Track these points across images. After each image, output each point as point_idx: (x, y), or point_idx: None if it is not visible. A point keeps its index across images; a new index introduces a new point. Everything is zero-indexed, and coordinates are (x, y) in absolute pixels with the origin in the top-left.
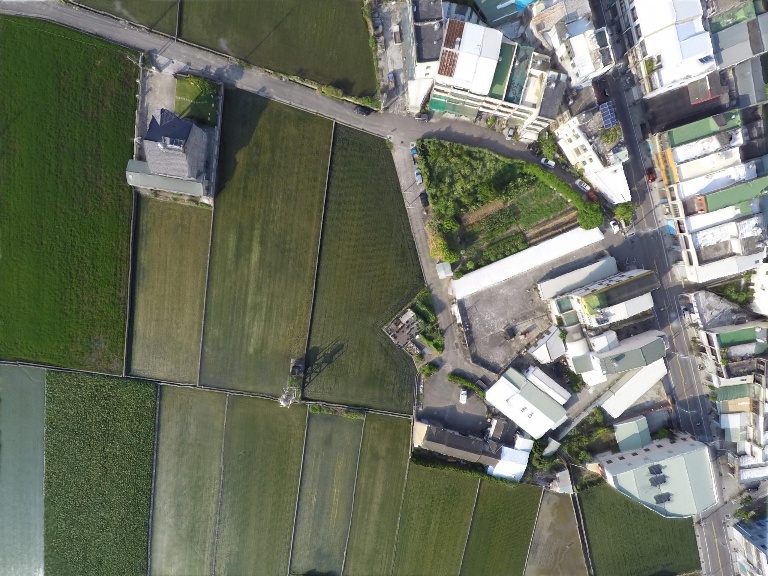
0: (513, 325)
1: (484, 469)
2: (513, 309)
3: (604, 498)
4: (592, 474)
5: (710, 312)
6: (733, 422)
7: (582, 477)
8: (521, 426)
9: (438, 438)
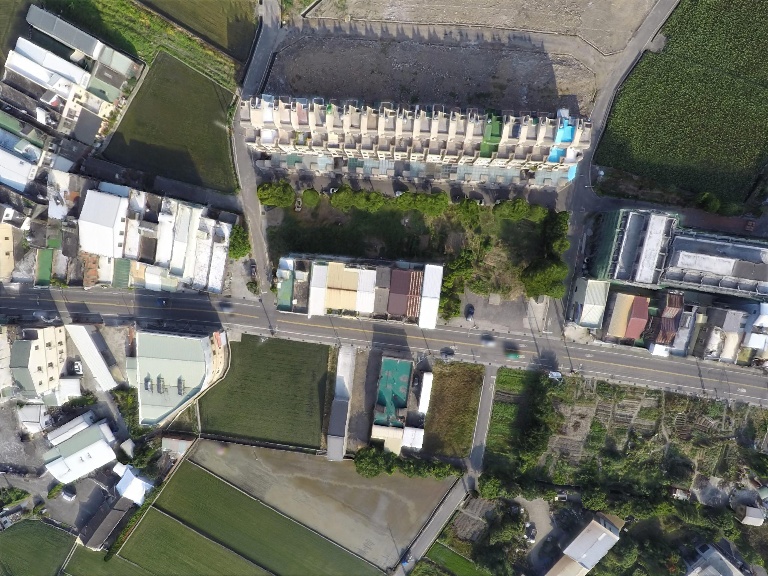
0: (20, 430)
1: (136, 507)
2: (6, 425)
3: (218, 410)
4: (187, 413)
5: (33, 272)
6: (154, 280)
7: (187, 423)
8: (102, 464)
9: (88, 535)
